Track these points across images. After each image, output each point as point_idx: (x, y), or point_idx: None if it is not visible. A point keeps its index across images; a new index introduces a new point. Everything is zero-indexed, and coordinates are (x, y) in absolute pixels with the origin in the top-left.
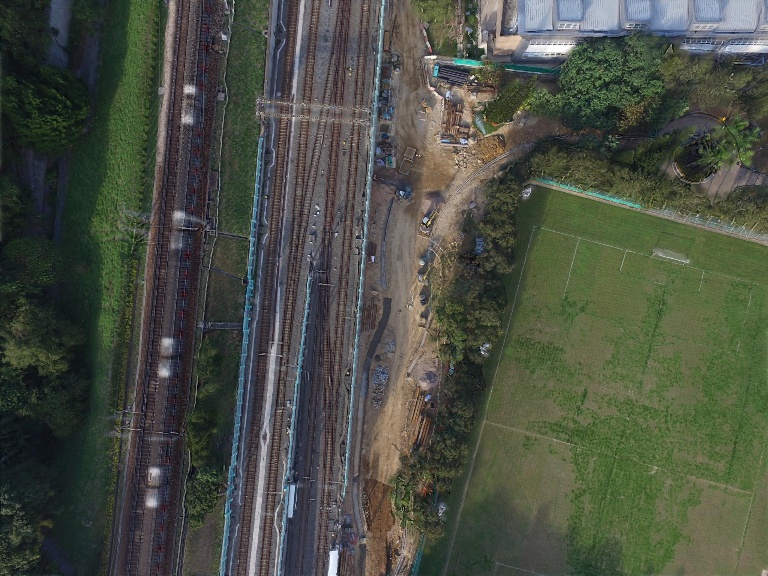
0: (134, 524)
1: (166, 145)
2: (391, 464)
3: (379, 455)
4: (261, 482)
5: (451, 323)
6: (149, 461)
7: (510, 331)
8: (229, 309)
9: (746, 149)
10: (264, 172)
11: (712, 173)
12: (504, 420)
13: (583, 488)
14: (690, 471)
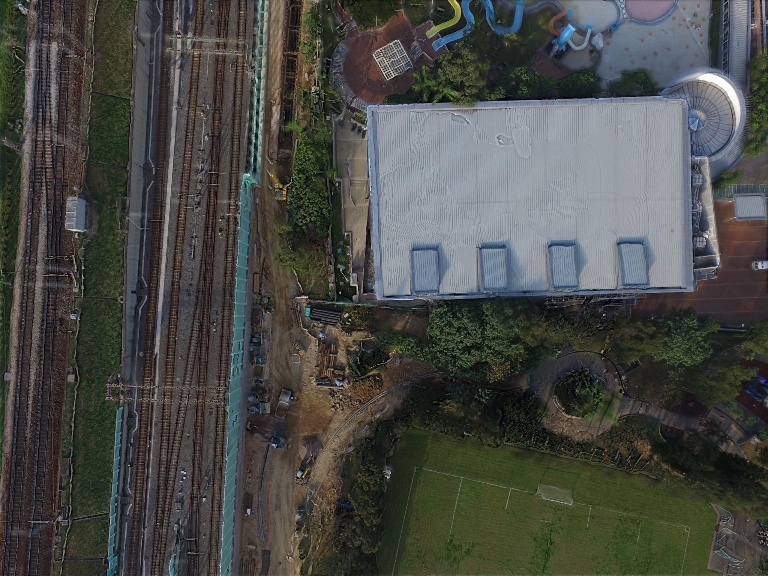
0: None
1: (13, 435)
2: None
3: None
4: None
5: None
6: None
7: None
8: None
9: (628, 377)
10: (127, 437)
11: (594, 405)
12: None
13: None
14: None
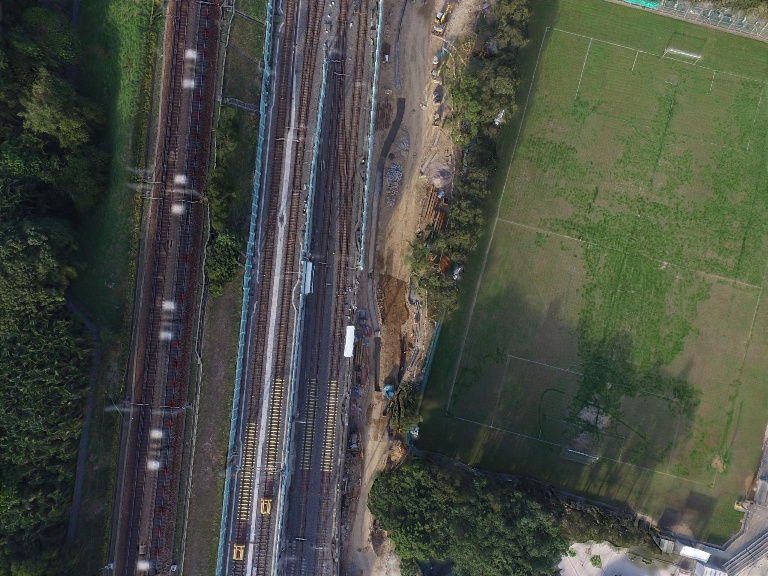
0: (155, 289)
1: None
2: (405, 260)
3: (393, 251)
4: (278, 262)
5: (466, 96)
6: (169, 229)
7: (522, 131)
8: (246, 90)
9: None
10: None
11: None
12: (516, 217)
13: (594, 283)
14: (699, 266)
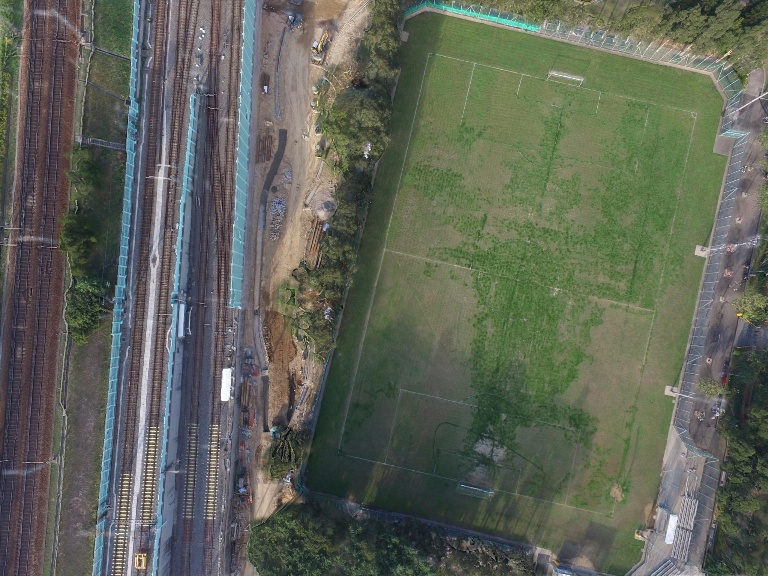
0: (15, 340)
1: None
2: None
3: (279, 287)
4: (151, 304)
5: (334, 129)
6: (29, 276)
7: (408, 159)
8: (111, 129)
9: None
10: None
11: None
12: (404, 248)
13: (485, 312)
14: (592, 291)
